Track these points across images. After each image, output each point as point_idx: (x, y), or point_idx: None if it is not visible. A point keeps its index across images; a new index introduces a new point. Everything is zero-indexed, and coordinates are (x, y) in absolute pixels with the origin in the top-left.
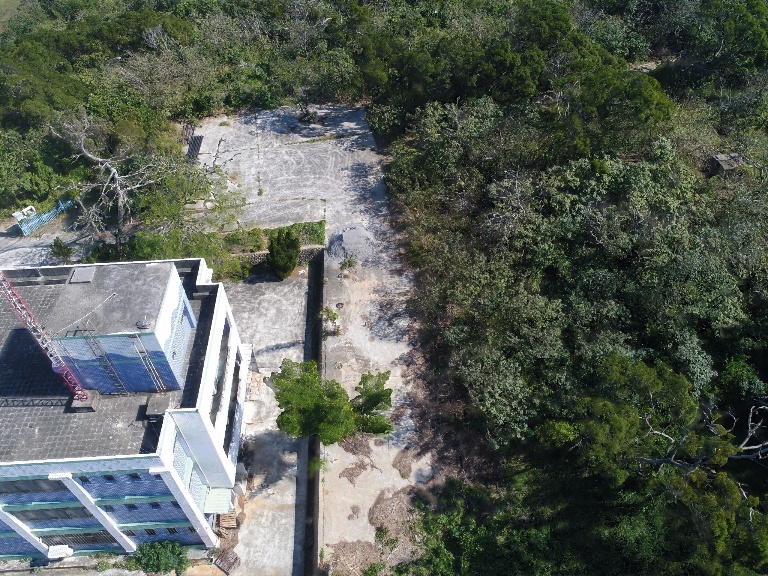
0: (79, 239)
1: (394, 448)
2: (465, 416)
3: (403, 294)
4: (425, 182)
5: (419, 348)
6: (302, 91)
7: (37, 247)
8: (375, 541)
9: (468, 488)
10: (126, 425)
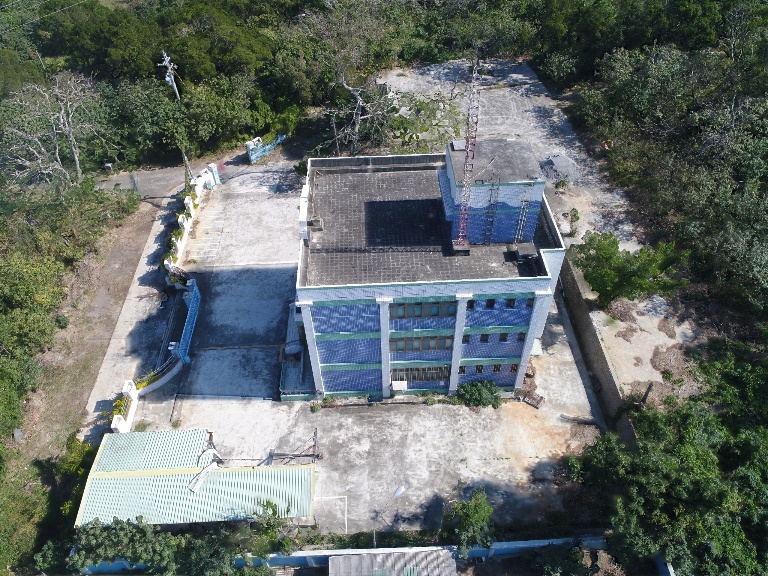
0: None
1: (655, 317)
2: (710, 294)
3: (619, 206)
4: (621, 116)
5: (649, 246)
6: (482, 43)
7: (268, 172)
8: (664, 381)
9: (731, 344)
10: (500, 264)
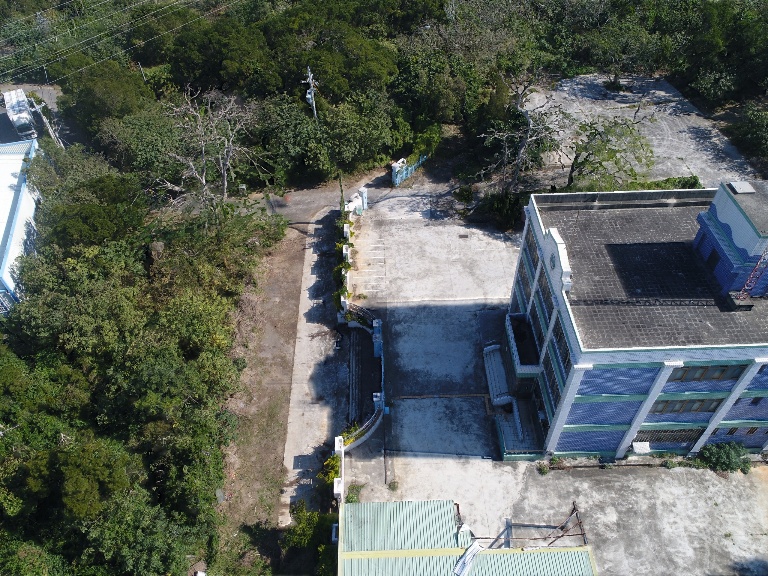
0: (453, 190)
1: None
2: None
3: None
4: None
5: None
6: (627, 58)
7: (415, 196)
8: None
9: None
10: None
